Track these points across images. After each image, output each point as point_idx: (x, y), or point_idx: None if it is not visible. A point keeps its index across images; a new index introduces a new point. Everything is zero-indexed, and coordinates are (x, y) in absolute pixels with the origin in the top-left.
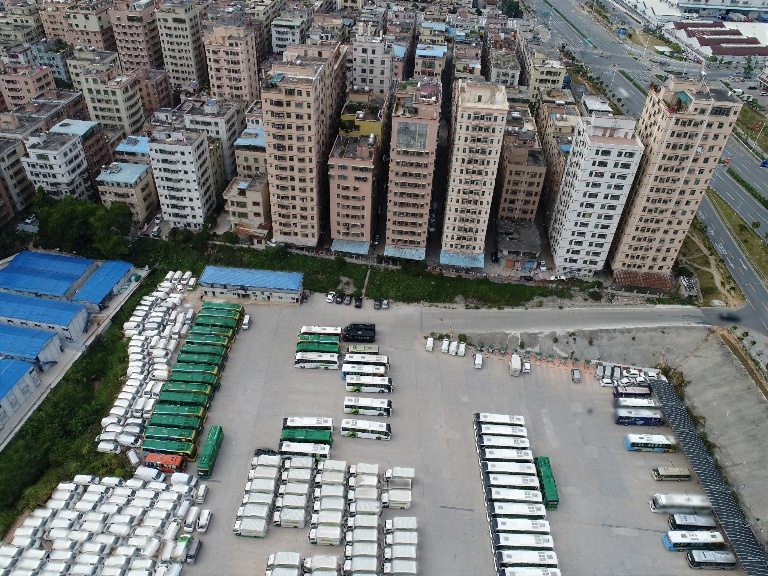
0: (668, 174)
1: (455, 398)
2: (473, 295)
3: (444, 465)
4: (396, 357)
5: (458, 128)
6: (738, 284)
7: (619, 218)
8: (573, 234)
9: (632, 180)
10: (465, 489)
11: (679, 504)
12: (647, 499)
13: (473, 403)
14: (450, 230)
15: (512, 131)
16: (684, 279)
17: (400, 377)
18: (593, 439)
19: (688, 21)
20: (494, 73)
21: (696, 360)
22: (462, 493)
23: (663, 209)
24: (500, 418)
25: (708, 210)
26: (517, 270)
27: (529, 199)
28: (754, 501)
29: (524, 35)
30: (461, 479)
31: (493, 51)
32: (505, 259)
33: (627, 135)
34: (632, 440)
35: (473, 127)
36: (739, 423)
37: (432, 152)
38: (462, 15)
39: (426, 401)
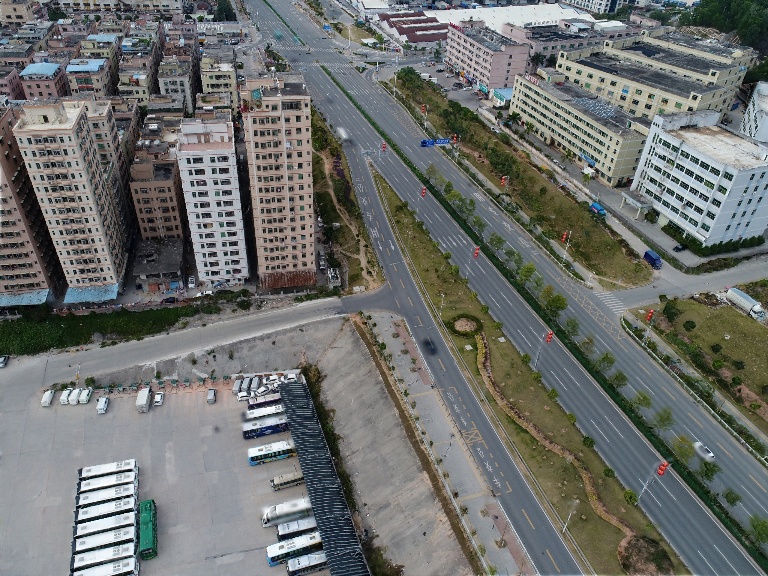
0: (270, 173)
1: (66, 456)
2: (111, 330)
3: (32, 541)
4: (2, 423)
5: (23, 155)
6: (382, 266)
7: (242, 223)
8: (203, 247)
9: (237, 184)
10: (52, 564)
11: (293, 510)
12: (261, 514)
13: (86, 456)
14: (68, 265)
15: (143, 145)
16: (330, 271)
17: (1, 447)
18: (217, 463)
19: (391, 12)
20: (161, 83)
21: (333, 352)
22: (47, 570)
23: (280, 208)
24: (105, 468)
25: (372, 196)
26: (163, 293)
27: (168, 215)
28: (364, 486)
29: (208, 39)
30: (50, 553)
31: (163, 59)
32: (146, 284)
33: (223, 139)
34: (250, 455)
35: (39, 152)
36: (360, 409)
37: (5, 185)
38: (140, 23)
39: (27, 468)
